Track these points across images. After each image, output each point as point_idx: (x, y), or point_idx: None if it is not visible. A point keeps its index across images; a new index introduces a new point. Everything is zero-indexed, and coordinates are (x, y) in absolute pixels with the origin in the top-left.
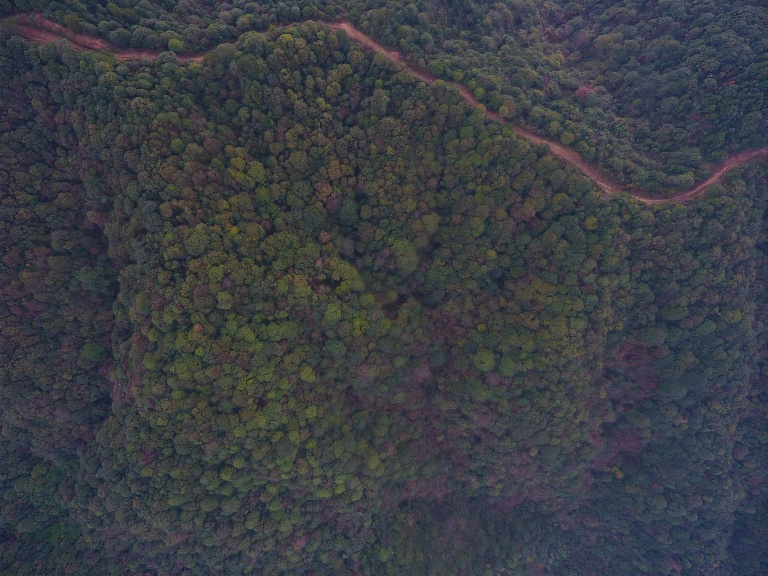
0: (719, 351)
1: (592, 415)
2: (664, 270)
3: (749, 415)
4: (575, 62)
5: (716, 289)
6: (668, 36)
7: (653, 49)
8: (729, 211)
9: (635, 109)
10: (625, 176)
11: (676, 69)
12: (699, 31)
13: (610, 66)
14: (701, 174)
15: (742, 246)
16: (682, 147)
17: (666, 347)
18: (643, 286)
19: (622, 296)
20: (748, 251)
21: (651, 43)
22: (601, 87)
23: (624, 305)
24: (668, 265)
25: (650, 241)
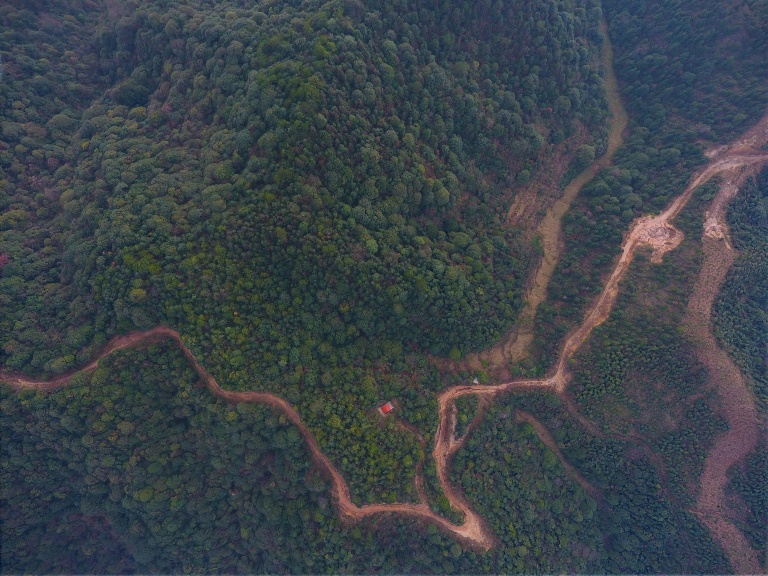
0: (150, 524)
1: (84, 571)
2: (57, 452)
3: (243, 572)
4: (51, 214)
5: (113, 471)
6: (93, 203)
7: (82, 215)
8: (80, 404)
9: (62, 276)
10: (6, 358)
11: (85, 241)
12: (111, 201)
13: (65, 224)
14: (78, 358)
15: (120, 433)
16: (83, 323)
17: (110, 516)
18: (50, 464)
19: (28, 474)
20: (138, 434)
21: (85, 207)
22: (45, 249)
23: (37, 481)
24: (55, 448)
25: (23, 428)
